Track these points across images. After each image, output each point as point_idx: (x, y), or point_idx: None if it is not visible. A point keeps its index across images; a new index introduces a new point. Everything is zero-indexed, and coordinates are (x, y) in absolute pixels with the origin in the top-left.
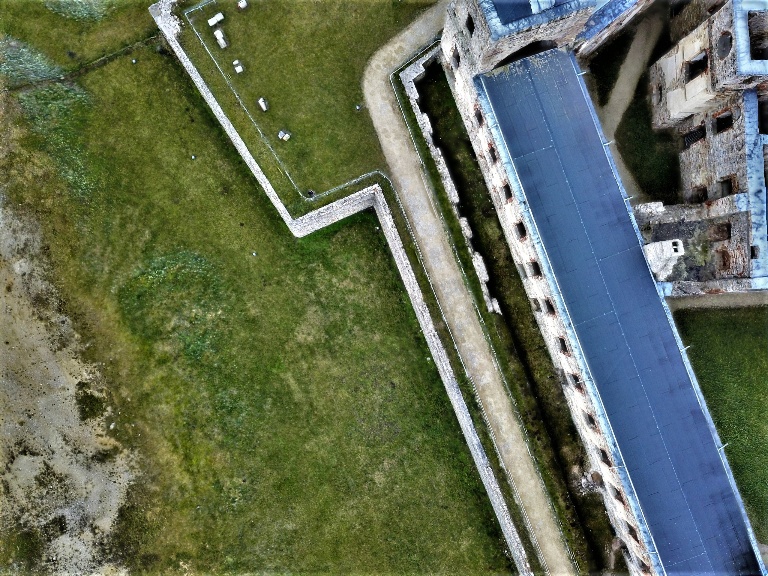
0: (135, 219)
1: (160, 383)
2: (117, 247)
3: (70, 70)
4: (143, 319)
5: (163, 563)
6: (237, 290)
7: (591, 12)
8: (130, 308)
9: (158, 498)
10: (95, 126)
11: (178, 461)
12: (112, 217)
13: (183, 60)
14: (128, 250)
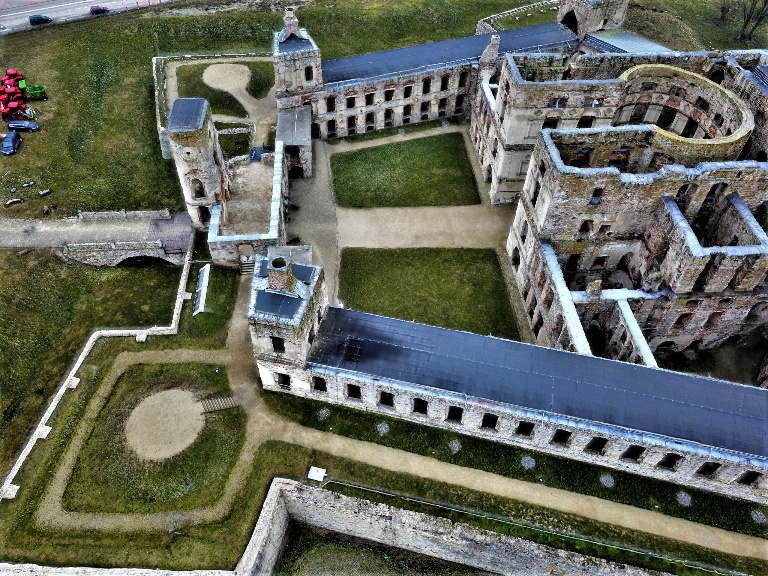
0: (472, 8)
1: (406, 5)
2: (460, 3)
3: (530, 1)
4: (432, 3)
5: (333, 2)
6: (447, 28)
7: (589, 8)
8: (436, 1)
9: (359, 2)
10: (508, 3)
11: (374, 7)
12: (472, 3)
13: (541, 2)
14: (459, 5)
